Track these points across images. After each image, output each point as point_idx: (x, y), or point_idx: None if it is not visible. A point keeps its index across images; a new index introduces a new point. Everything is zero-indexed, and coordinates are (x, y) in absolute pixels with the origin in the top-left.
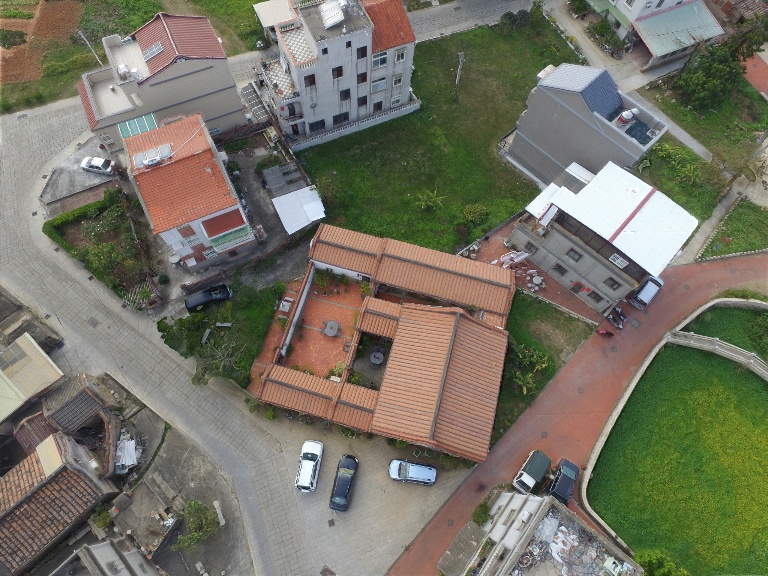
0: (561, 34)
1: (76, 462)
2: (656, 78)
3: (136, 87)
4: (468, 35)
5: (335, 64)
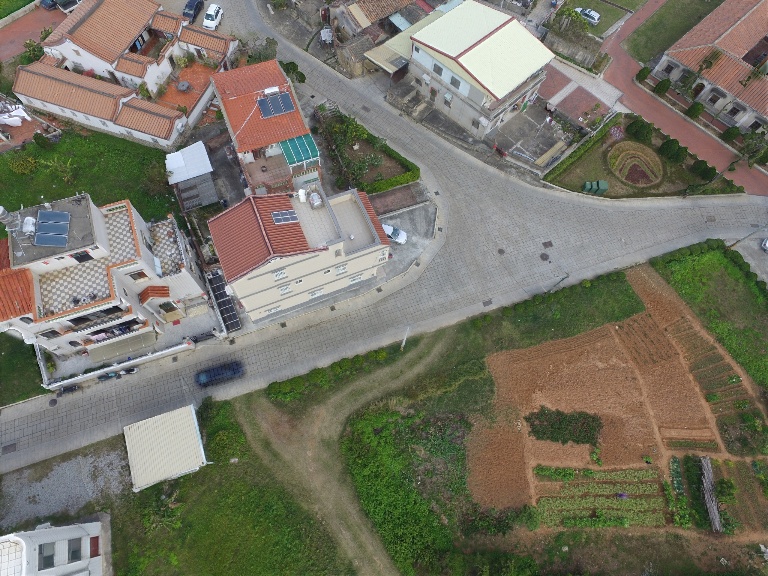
0: None
1: (343, 12)
2: None
3: None
4: None
5: None
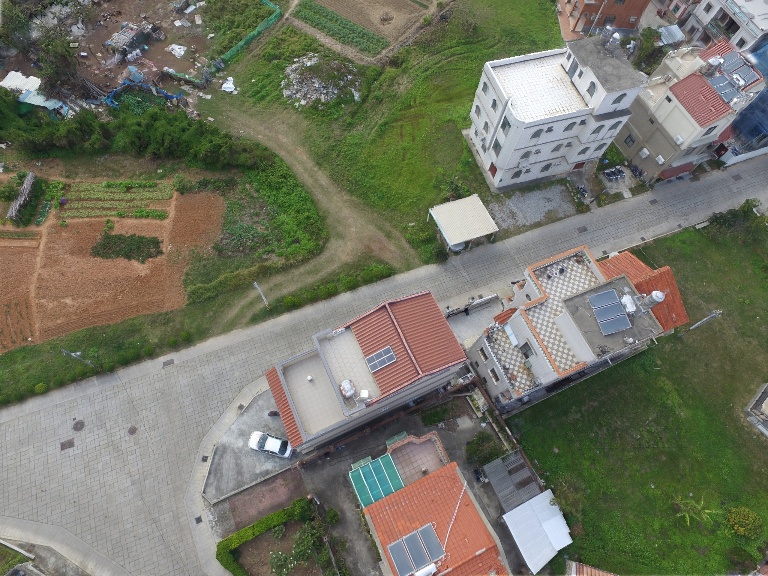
0: None
1: None
2: None
3: None
4: (674, 241)
5: None
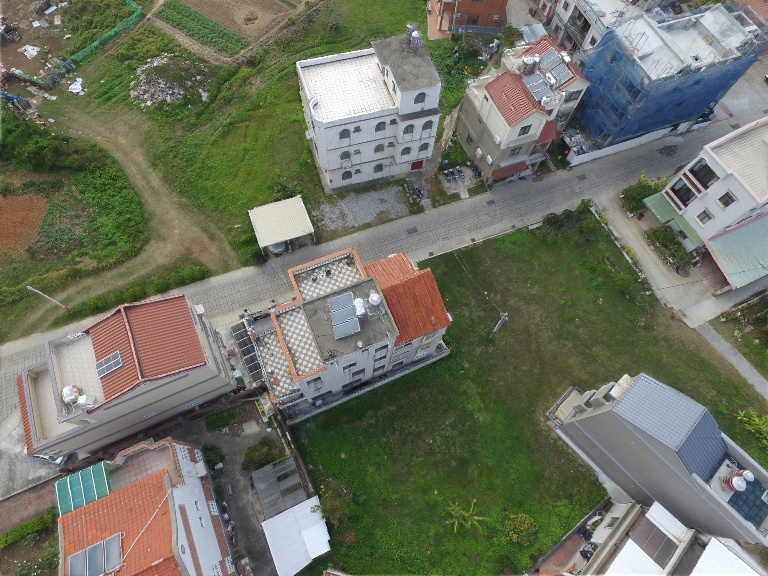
0: (615, 241)
1: None
2: (732, 305)
3: (85, 415)
4: (504, 242)
5: (347, 364)
